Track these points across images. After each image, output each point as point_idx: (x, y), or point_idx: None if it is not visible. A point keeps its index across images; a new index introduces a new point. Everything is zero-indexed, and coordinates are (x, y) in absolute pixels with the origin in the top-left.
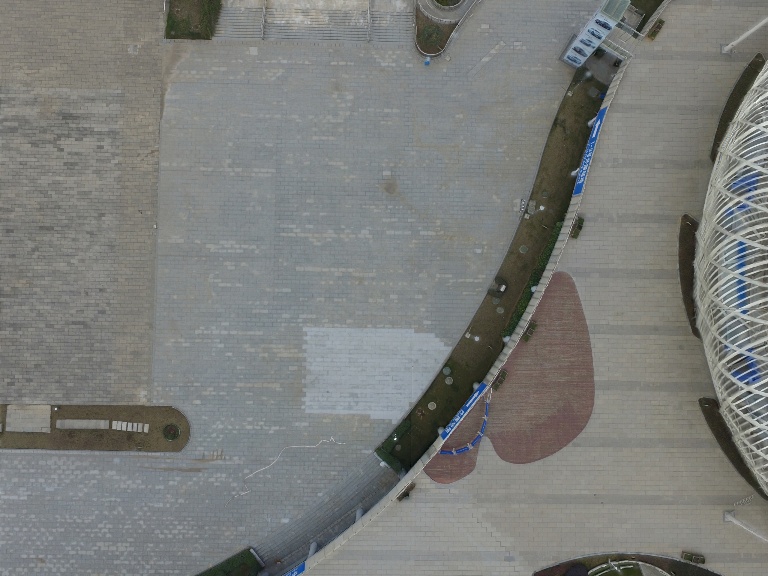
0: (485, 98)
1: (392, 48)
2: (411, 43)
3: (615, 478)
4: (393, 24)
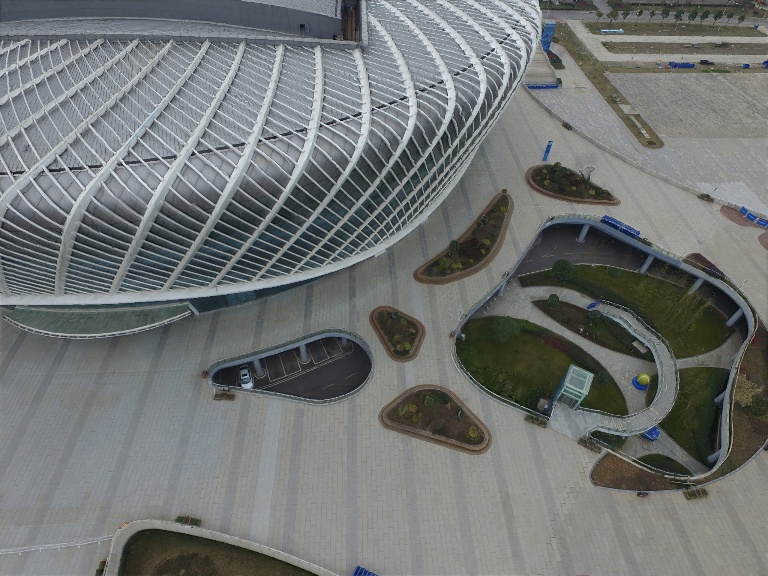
0: None
1: None
2: None
3: None
4: None
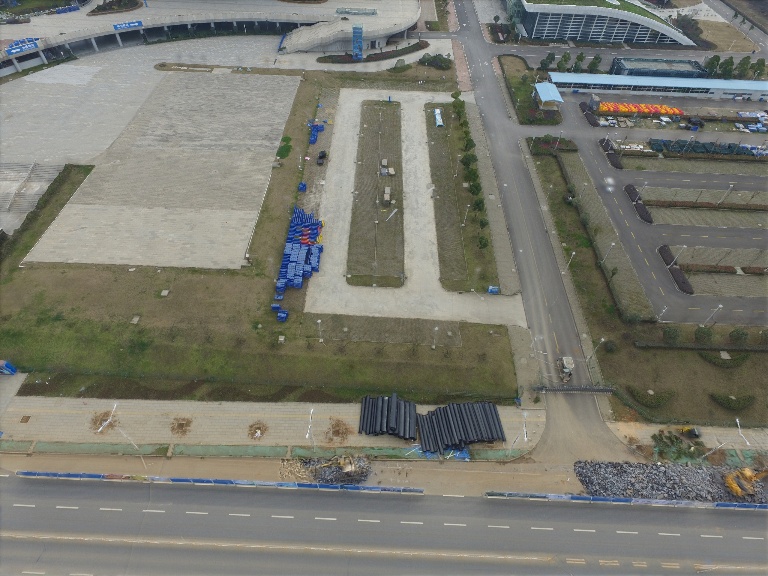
0: None
1: None
2: None
3: None
4: None
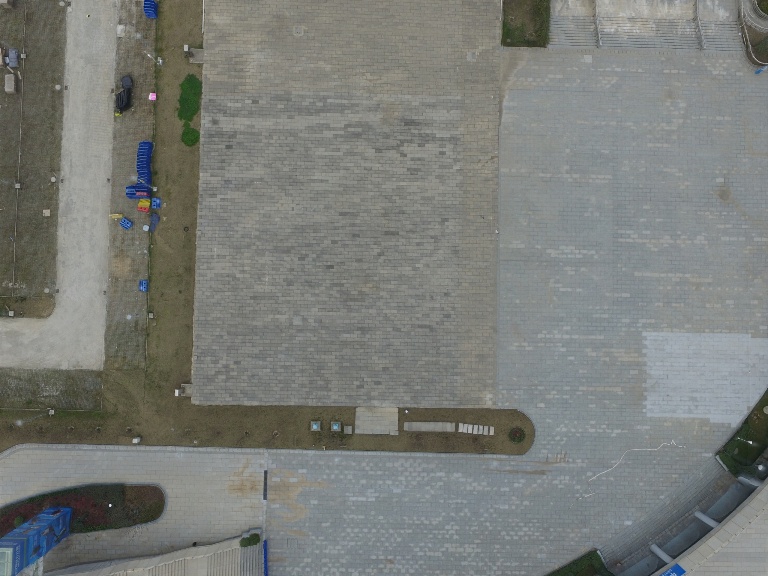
0: None
1: (722, 57)
2: (741, 52)
3: None
4: (719, 33)
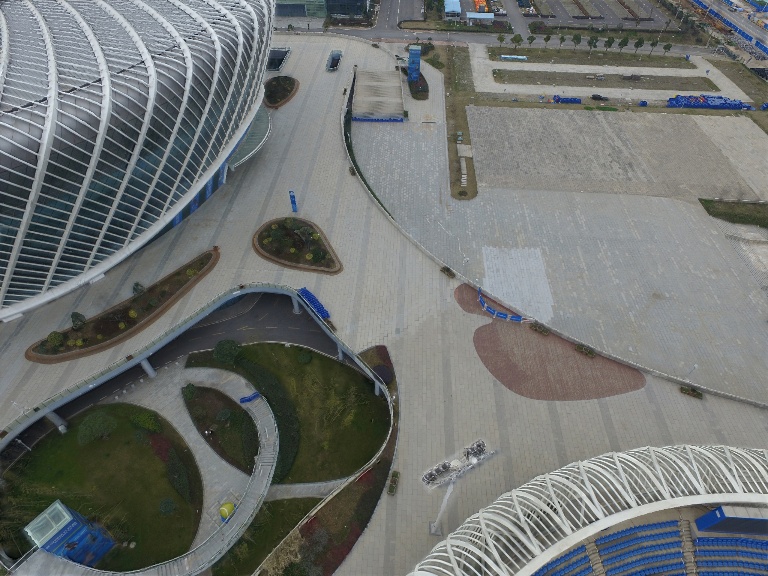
0: (766, 360)
1: (766, 302)
2: None
3: (468, 414)
4: None
